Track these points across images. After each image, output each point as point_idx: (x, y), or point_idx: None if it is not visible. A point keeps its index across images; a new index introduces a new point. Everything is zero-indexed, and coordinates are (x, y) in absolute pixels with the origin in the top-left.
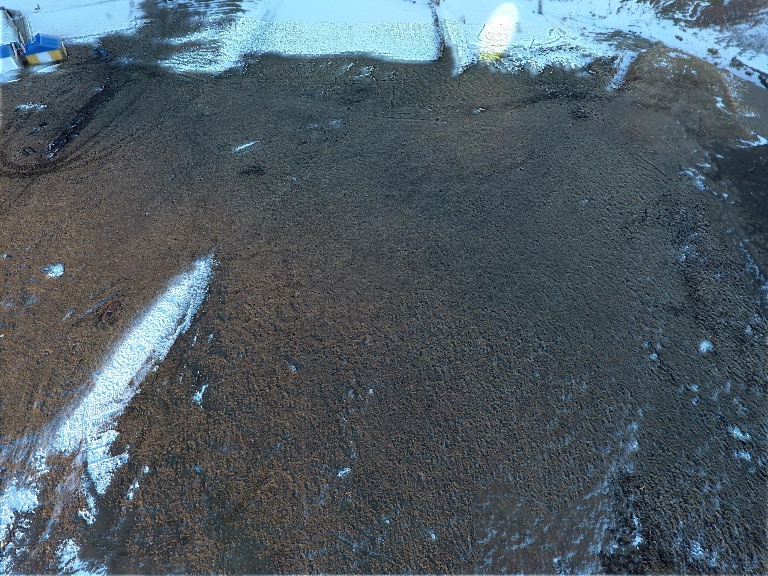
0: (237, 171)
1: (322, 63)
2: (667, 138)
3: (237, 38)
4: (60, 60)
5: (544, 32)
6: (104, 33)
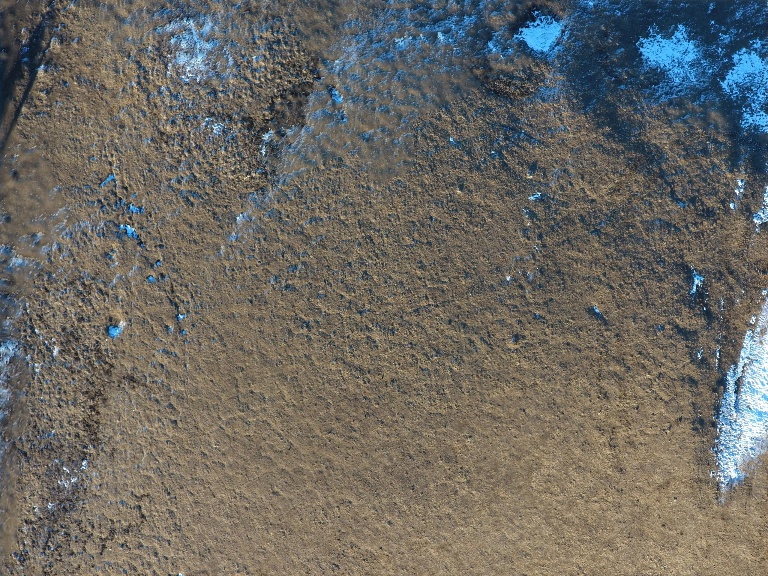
0: None
1: None
2: None
3: None
4: None
5: None
6: None
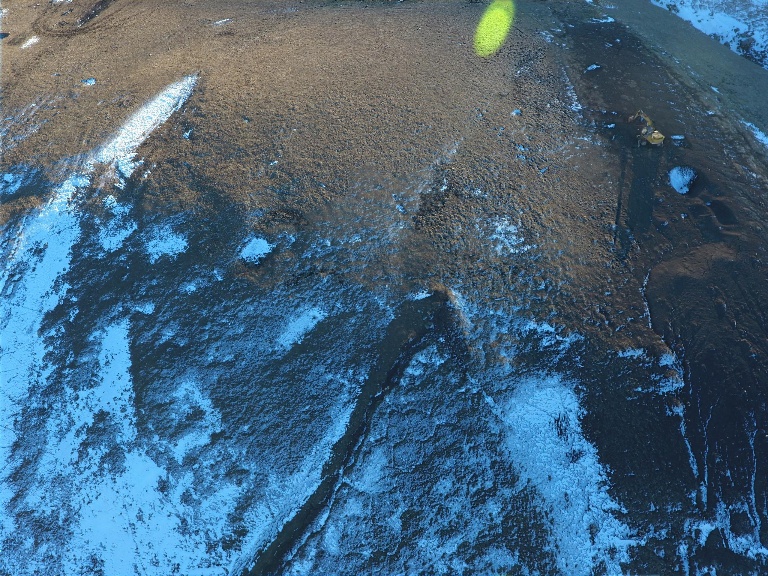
0: (215, 34)
1: None
2: (535, 15)
3: None
4: None
5: None
6: None
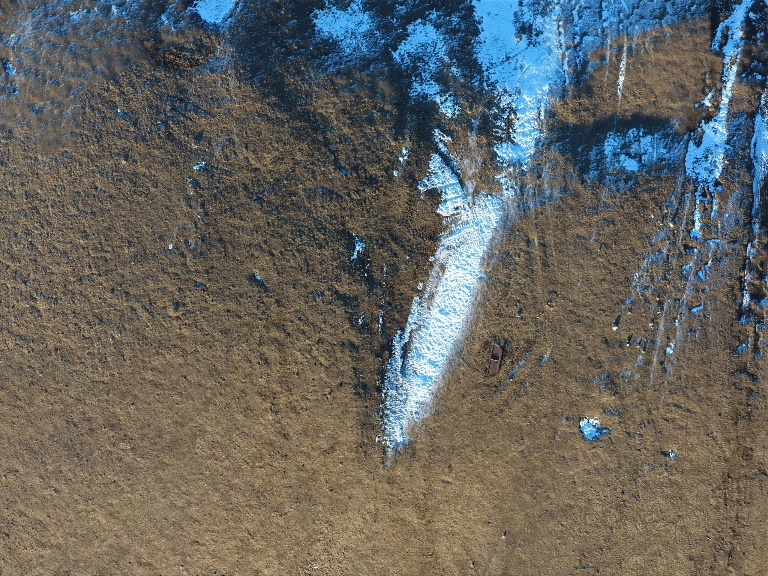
0: None
1: None
2: None
3: None
4: None
5: None
6: None
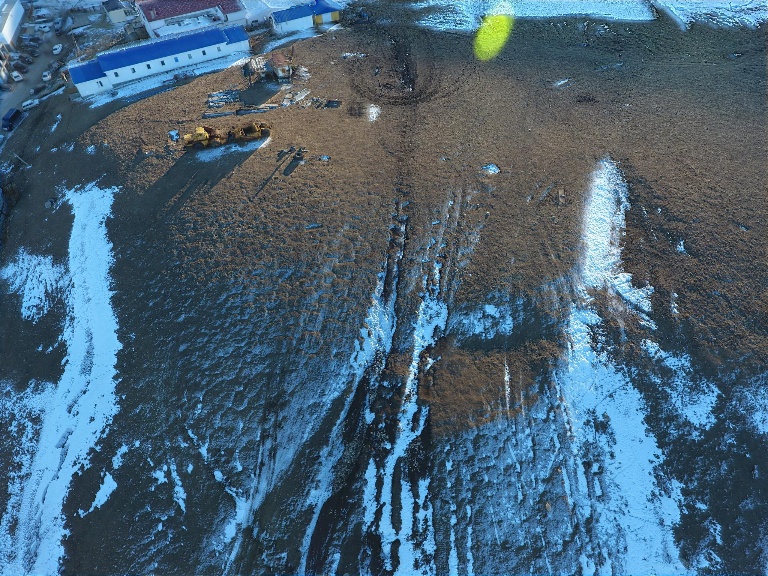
0: (574, 100)
1: (558, 22)
2: None
3: (466, 4)
4: (337, 21)
5: None
6: (349, 0)
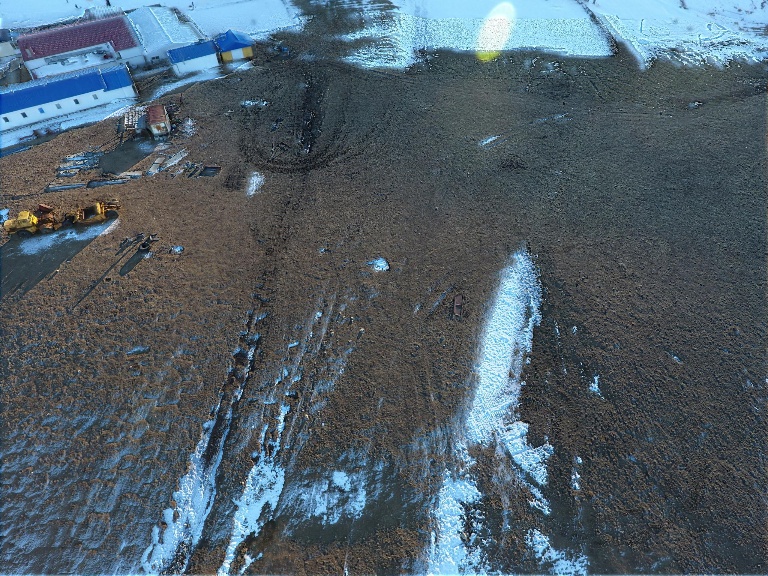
0: (498, 165)
1: (504, 59)
2: None
3: (405, 34)
4: (250, 57)
5: (703, 27)
6: (273, 30)
